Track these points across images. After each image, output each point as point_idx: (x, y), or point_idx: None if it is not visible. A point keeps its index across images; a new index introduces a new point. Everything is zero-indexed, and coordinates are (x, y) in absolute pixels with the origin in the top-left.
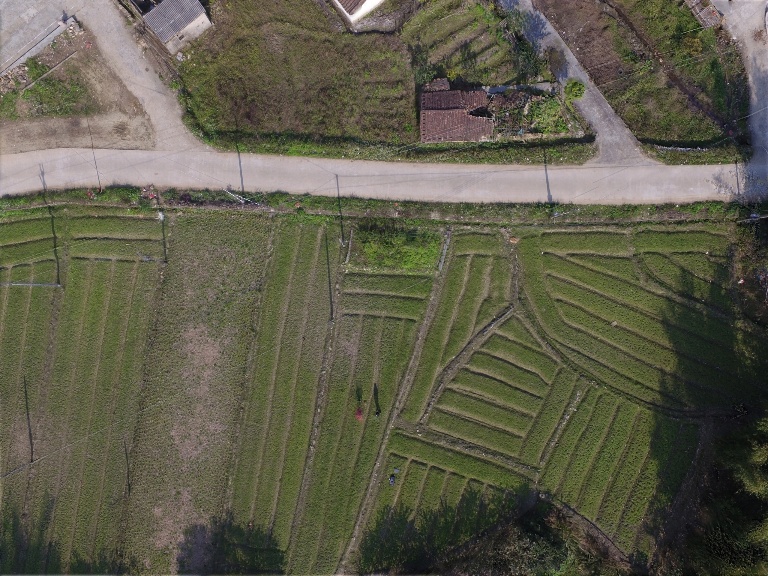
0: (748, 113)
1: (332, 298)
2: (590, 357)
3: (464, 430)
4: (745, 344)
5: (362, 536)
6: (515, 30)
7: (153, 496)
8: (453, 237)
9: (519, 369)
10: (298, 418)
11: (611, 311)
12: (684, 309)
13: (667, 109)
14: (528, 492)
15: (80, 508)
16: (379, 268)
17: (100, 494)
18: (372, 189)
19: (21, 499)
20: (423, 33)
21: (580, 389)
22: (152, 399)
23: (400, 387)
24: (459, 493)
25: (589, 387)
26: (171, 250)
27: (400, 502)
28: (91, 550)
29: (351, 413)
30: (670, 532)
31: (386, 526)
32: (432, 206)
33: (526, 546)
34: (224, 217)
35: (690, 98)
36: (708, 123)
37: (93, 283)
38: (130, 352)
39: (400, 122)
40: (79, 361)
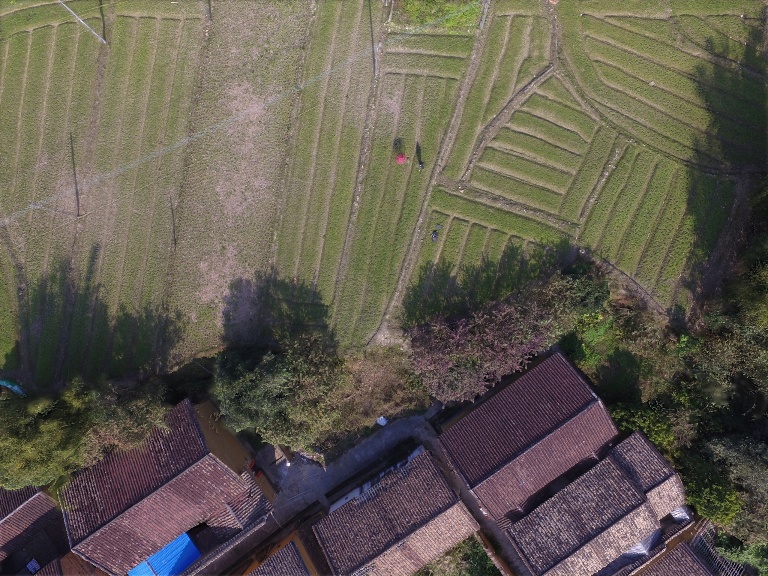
0: None
1: (375, 57)
2: (628, 117)
3: (505, 187)
4: None
5: (405, 292)
6: None
7: (199, 251)
8: None
9: (559, 127)
10: (342, 174)
11: (649, 71)
12: (720, 69)
13: None
14: (568, 247)
15: (126, 262)
16: (421, 27)
17: (146, 249)
18: None
19: (68, 254)
20: None
21: (619, 146)
22: (197, 155)
23: (442, 144)
24: (501, 248)
25: (628, 145)
26: (216, 9)
27: (443, 258)
28: (137, 304)
29: (394, 170)
30: (708, 285)
31: (429, 282)
32: None
33: (569, 284)
34: None
35: None
36: None
37: (139, 40)
38: (176, 108)
39: None
40: (125, 118)
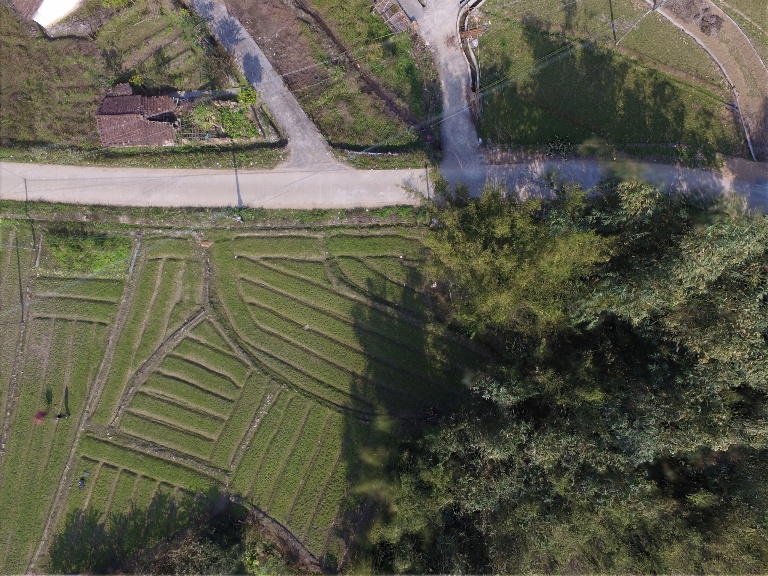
0: (441, 118)
1: (24, 302)
2: (283, 360)
3: (155, 433)
4: (436, 347)
5: (52, 539)
6: (211, 35)
7: None
8: (145, 241)
9: (210, 372)
10: None
11: (302, 315)
12: (375, 313)
13: (364, 114)
14: (218, 495)
15: None
16: (69, 272)
17: None
18: (61, 193)
19: None
20: (117, 38)
21: (270, 392)
22: None
23: (90, 390)
24: (149, 496)
25: (280, 390)
26: None
27: (90, 505)
28: None
29: (41, 416)
30: (359, 535)
31: (76, 529)
32: (120, 210)
33: (195, 549)
34: None
35: (388, 103)
36: (404, 128)
37: None
38: None
39: (91, 126)
40: None
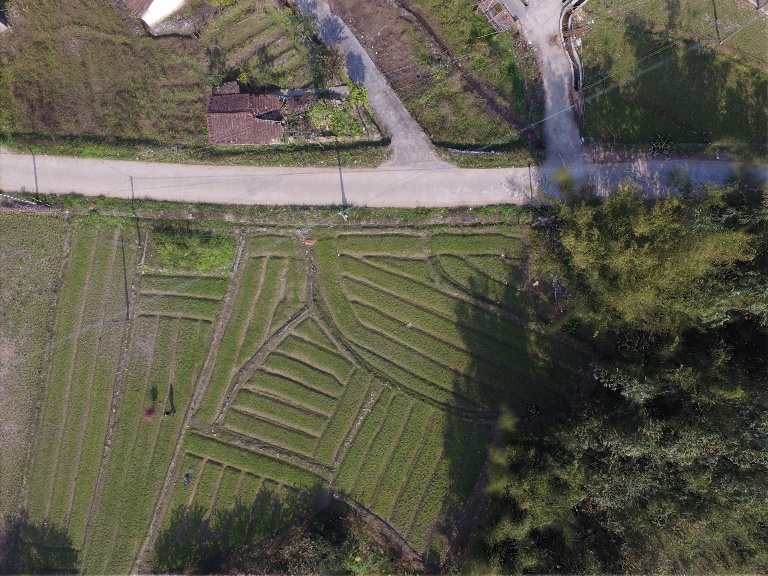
0: (543, 117)
1: (129, 299)
2: (385, 358)
3: (259, 430)
4: (538, 346)
5: (157, 535)
6: (313, 34)
7: None
8: (249, 239)
9: (314, 370)
10: (93, 418)
11: (406, 313)
12: (478, 311)
13: (465, 113)
14: (322, 492)
15: None
16: (174, 269)
17: None
18: (166, 191)
19: None
20: (221, 37)
21: (374, 390)
22: None
23: (195, 387)
24: (253, 493)
25: (383, 388)
26: None
27: (195, 502)
28: None
29: (146, 413)
30: (462, 532)
31: (181, 525)
32: (226, 208)
33: (306, 545)
34: (21, 218)
35: (489, 102)
36: (505, 127)
37: None
38: None
39: (196, 125)
40: None
